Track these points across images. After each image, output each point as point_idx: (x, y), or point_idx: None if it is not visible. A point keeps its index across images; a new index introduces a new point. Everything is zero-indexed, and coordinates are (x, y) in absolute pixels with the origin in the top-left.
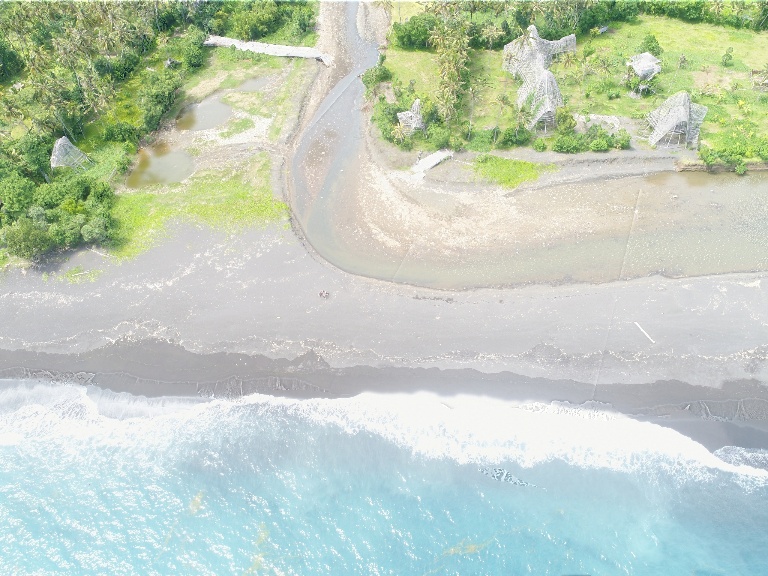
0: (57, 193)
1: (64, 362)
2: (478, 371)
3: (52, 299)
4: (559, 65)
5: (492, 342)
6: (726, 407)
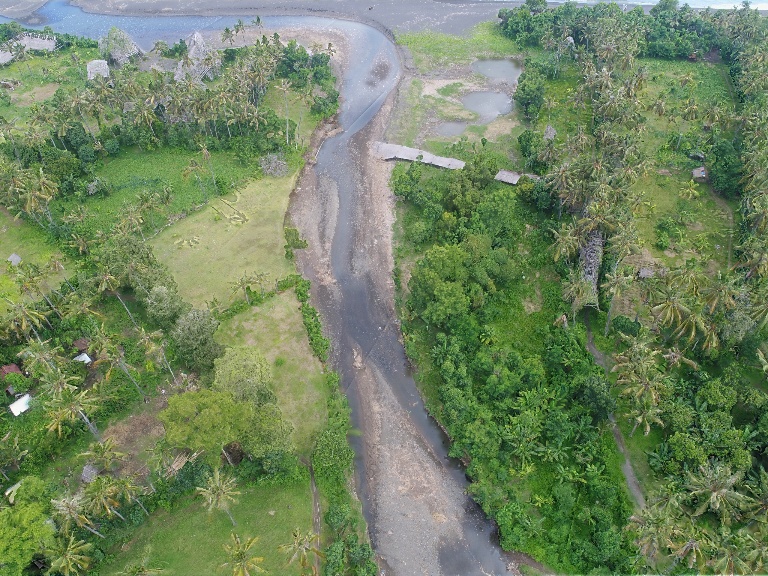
0: None
1: None
2: None
3: None
4: None
5: None
6: None
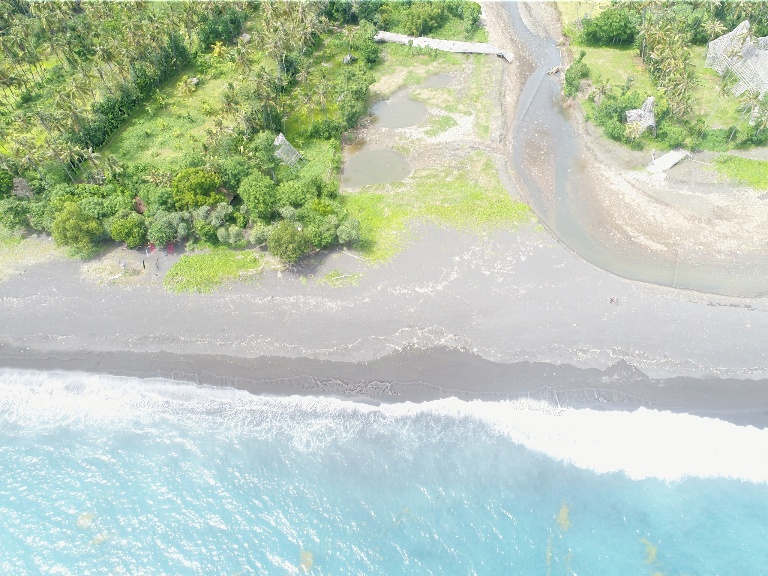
0: (300, 192)
1: (353, 371)
2: None
3: (319, 304)
4: None
5: None
6: None
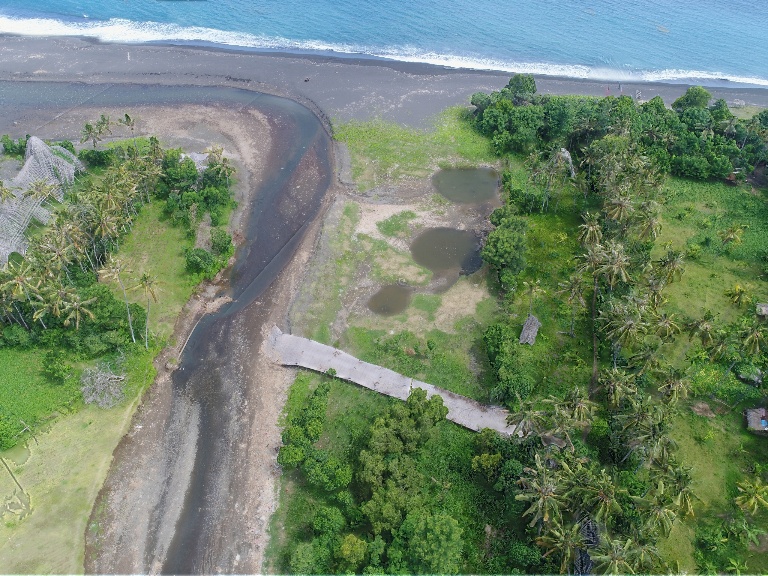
0: None
1: None
2: (228, 53)
3: (492, 88)
4: None
5: None
6: None
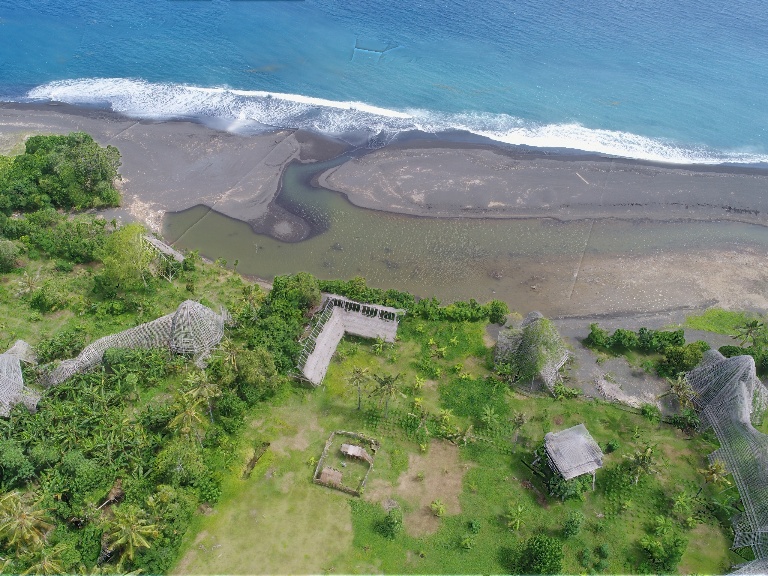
0: None
1: None
2: (689, 170)
3: None
4: (715, 574)
5: (686, 179)
6: (535, 153)
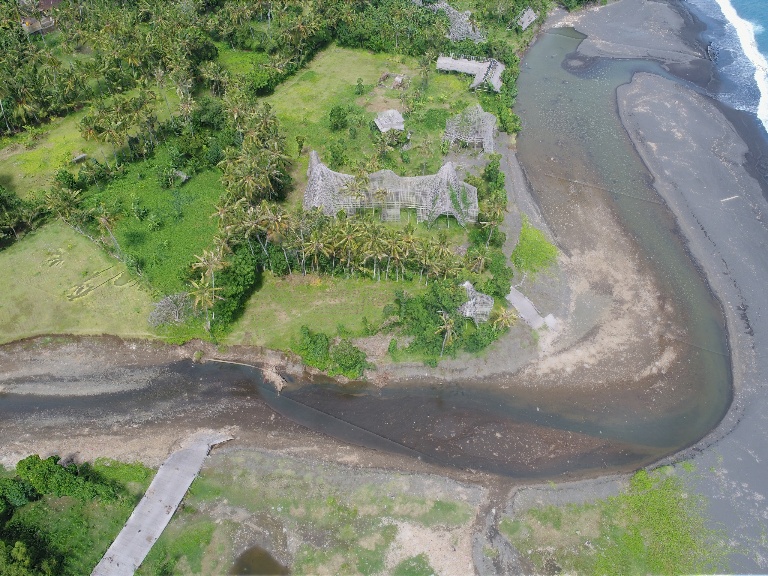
0: None
1: None
2: None
3: None
4: None
5: None
6: None
